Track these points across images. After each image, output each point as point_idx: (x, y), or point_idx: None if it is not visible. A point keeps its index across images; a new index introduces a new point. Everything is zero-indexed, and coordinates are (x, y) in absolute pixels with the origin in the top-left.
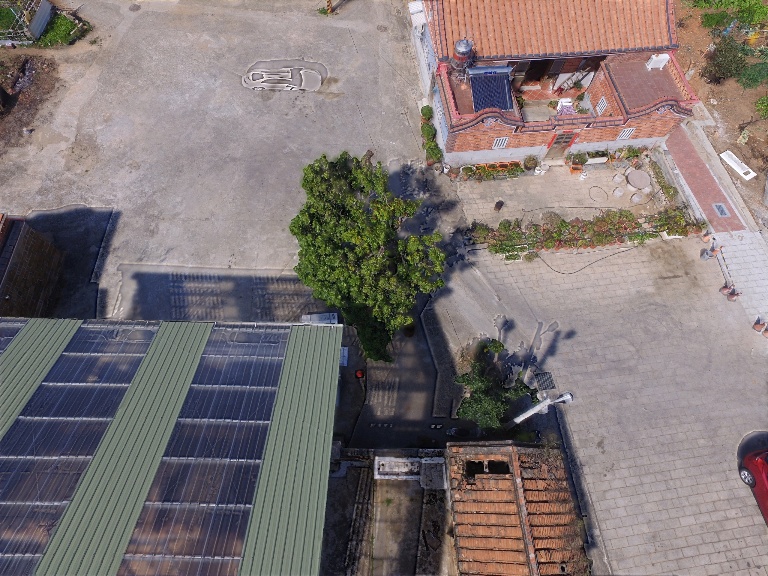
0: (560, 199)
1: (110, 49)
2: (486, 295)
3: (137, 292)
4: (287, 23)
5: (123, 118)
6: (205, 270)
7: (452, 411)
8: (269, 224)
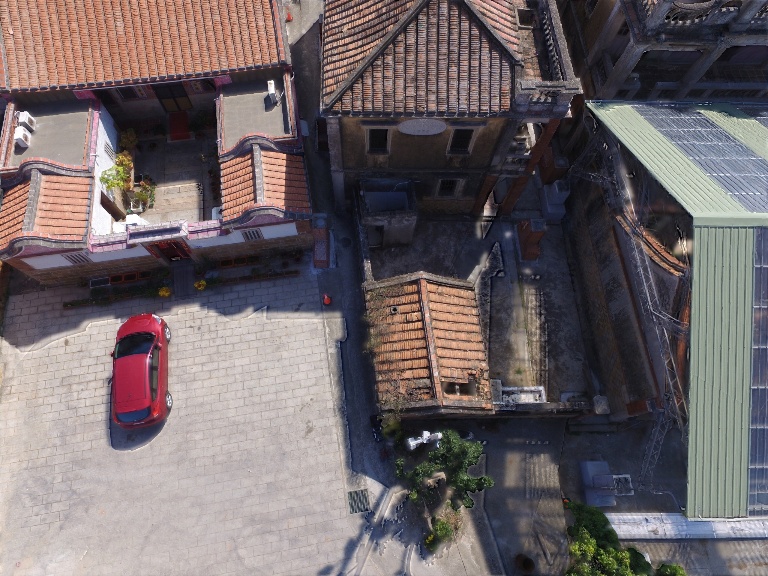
0: None
1: None
2: None
3: None
4: None
5: None
6: None
7: None
8: None
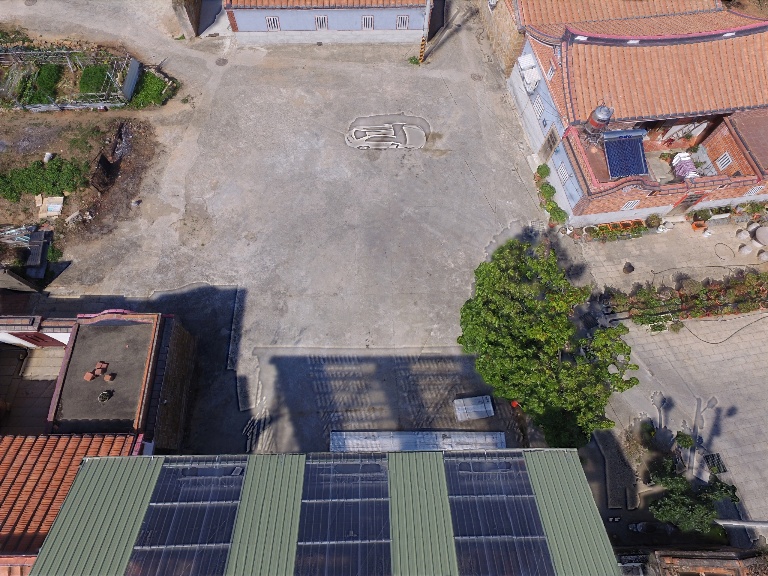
0: (687, 258)
1: (204, 108)
2: (638, 370)
3: (277, 379)
4: (380, 75)
5: (231, 185)
6: (343, 351)
7: (627, 501)
8: (400, 297)
